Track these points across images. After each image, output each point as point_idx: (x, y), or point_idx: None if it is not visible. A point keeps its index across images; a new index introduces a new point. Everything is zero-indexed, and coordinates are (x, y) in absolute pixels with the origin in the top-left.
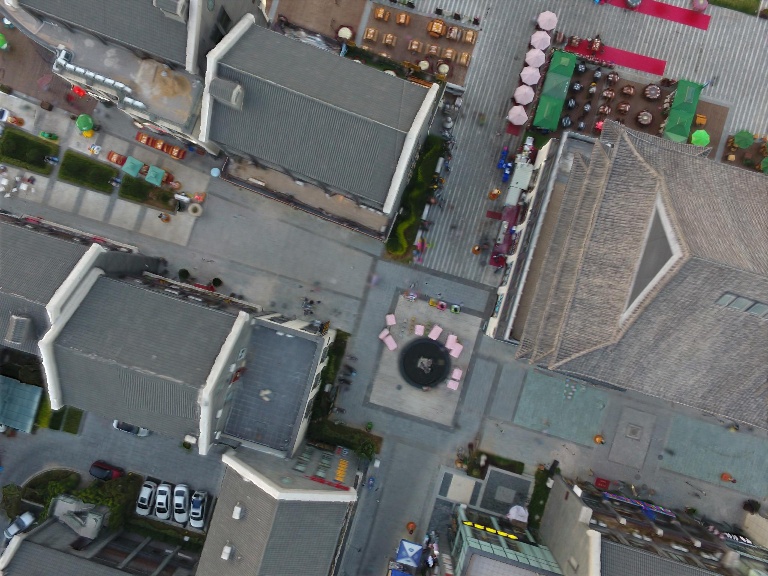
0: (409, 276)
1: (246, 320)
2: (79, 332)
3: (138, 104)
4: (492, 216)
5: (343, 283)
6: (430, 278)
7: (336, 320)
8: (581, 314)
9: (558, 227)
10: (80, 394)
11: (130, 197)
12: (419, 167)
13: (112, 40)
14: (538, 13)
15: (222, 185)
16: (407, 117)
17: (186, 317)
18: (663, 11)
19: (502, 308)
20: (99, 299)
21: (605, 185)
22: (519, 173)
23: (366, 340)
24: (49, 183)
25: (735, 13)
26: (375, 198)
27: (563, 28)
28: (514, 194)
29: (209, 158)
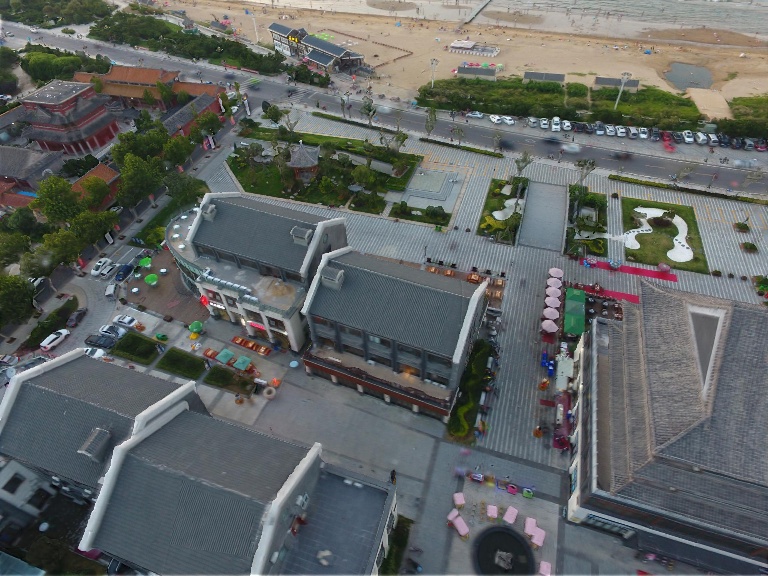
0: (473, 458)
1: (319, 454)
2: (155, 447)
3: (254, 299)
4: (546, 404)
5: (405, 464)
6: (495, 460)
7: (397, 504)
8: (663, 403)
9: (613, 374)
10: (121, 527)
11: (213, 382)
12: (472, 363)
13: (246, 264)
14: (547, 272)
15: (297, 375)
16: (468, 293)
17: (260, 445)
18: (639, 272)
19: (580, 473)
20: (180, 425)
21: (641, 311)
22: (562, 365)
23: (431, 528)
24: (145, 371)
25: (693, 273)
26: (445, 352)
27: (568, 280)
28: (562, 381)
29: (290, 355)
